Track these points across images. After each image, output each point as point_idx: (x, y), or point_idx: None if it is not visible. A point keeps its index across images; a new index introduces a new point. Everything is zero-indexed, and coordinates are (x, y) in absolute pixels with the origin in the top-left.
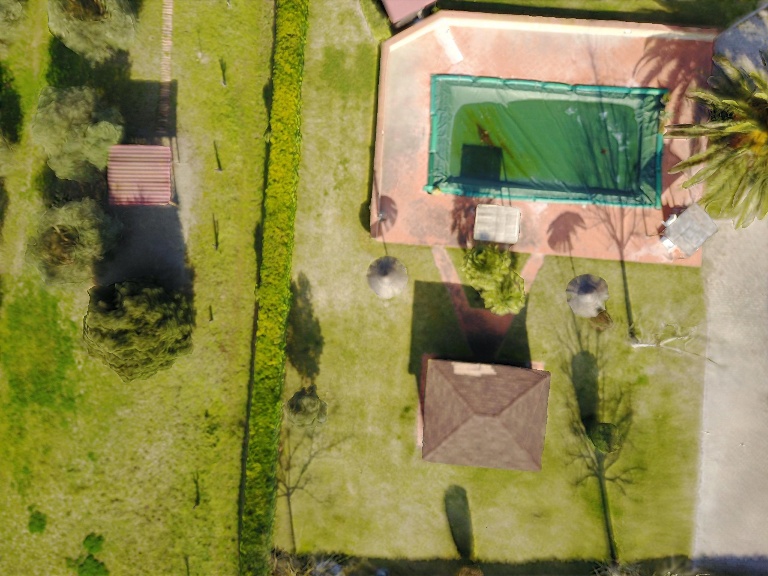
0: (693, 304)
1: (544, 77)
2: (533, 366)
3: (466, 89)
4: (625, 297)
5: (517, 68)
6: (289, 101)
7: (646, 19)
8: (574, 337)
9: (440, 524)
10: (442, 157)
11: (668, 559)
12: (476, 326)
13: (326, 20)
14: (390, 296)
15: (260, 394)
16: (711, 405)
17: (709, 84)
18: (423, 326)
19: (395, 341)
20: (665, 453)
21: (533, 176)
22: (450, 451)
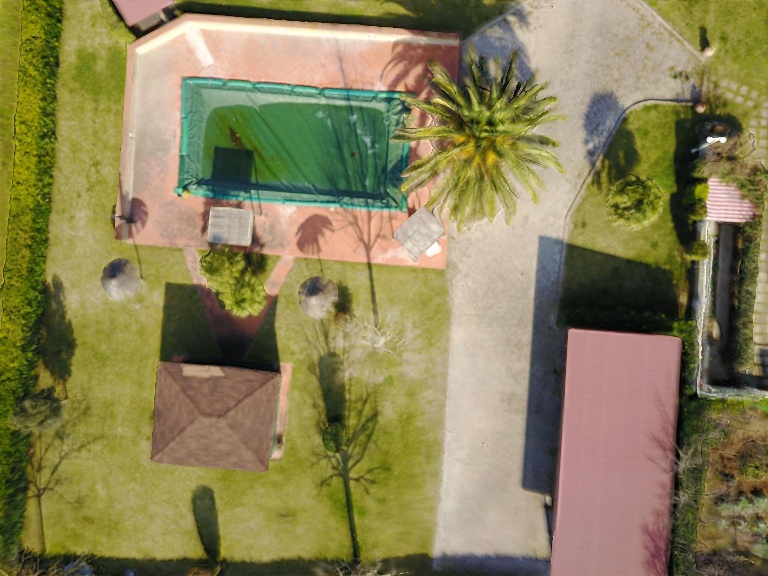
0: (438, 305)
1: (294, 80)
2: (281, 367)
3: (216, 92)
4: (372, 299)
5: (267, 71)
6: (33, 103)
7: (392, 23)
8: (321, 338)
9: (187, 524)
10: (192, 159)
11: (409, 557)
12: (226, 327)
13: (79, 22)
14: (122, 298)
15: (1, 396)
16: (454, 405)
17: (430, 88)
18: (173, 328)
19: (145, 343)
20: (408, 453)
21: (284, 179)
22: (177, 452)
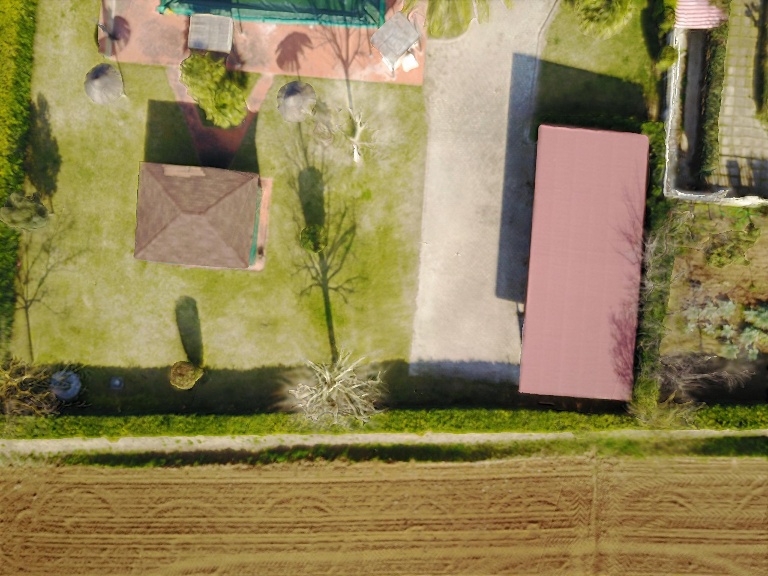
0: (415, 121)
1: None
2: (262, 182)
3: None
4: None
5: None
6: None
7: None
8: (301, 153)
9: (171, 333)
10: None
11: (386, 363)
12: (208, 144)
13: None
14: (105, 102)
15: None
16: (429, 217)
17: None
18: (156, 143)
19: (129, 158)
20: (385, 263)
21: None
22: (160, 249)
